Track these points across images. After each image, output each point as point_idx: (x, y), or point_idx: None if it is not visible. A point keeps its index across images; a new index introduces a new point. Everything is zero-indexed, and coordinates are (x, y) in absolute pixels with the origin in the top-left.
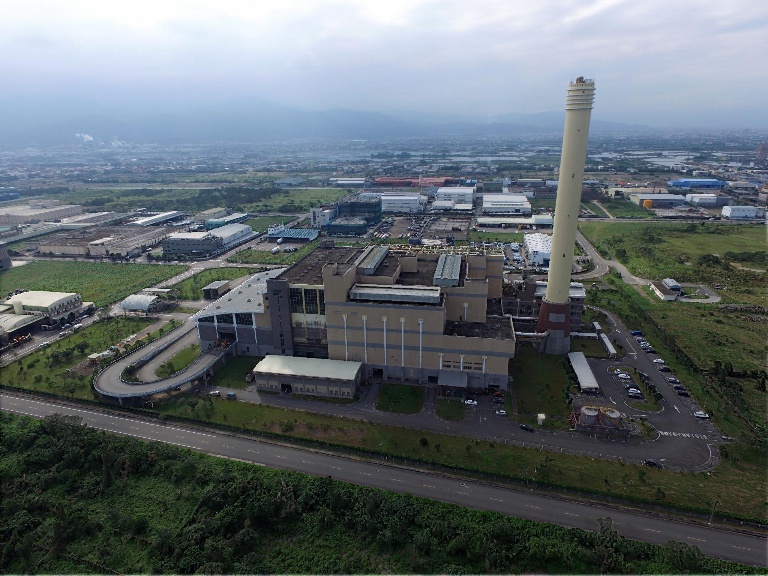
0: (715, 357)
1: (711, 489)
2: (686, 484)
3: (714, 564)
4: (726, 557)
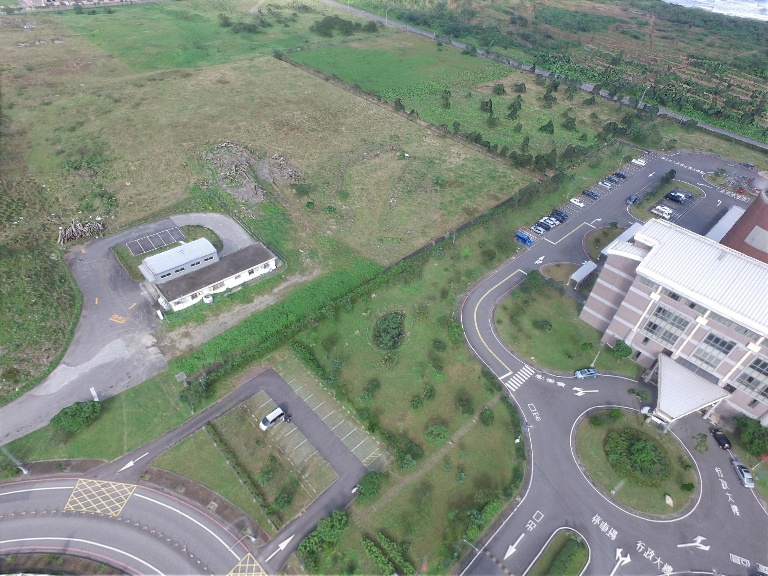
0: (493, 176)
1: (718, 146)
2: (734, 153)
3: (767, 139)
4: (752, 140)
